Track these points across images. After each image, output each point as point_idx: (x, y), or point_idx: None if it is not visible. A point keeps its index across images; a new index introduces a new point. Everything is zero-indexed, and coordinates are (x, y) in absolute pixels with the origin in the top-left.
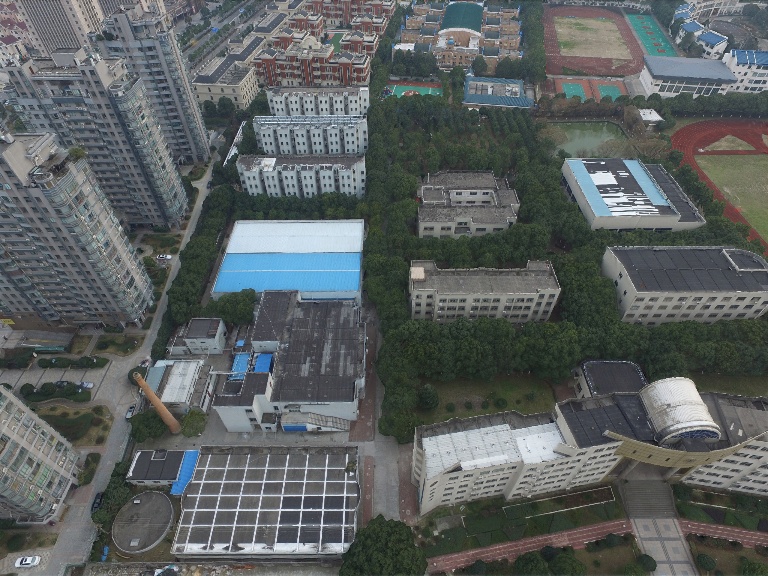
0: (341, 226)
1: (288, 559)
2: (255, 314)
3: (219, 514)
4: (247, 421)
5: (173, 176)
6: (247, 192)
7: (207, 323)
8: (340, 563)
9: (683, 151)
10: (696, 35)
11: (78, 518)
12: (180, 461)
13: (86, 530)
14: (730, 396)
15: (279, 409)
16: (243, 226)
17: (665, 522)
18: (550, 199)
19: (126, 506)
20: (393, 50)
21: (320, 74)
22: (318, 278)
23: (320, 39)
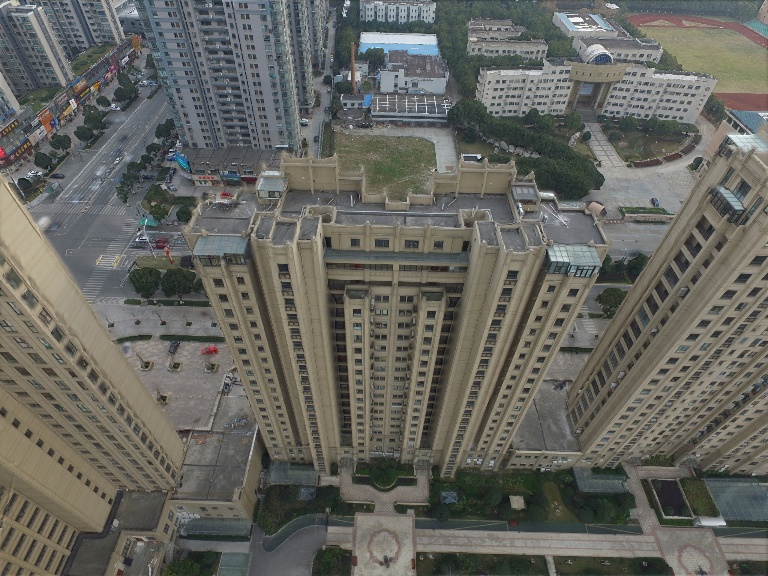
0: (423, 36)
1: (422, 121)
2: (385, 60)
3: (389, 106)
4: (393, 87)
5: (324, 6)
6: (365, 20)
7: (361, 61)
8: (444, 126)
9: None
10: None
11: (319, 114)
12: (364, 96)
13: (325, 116)
14: (622, 60)
15: (407, 84)
16: (366, 34)
17: (592, 123)
18: (545, 27)
19: (341, 111)
20: None
21: None
22: (415, 51)
23: None
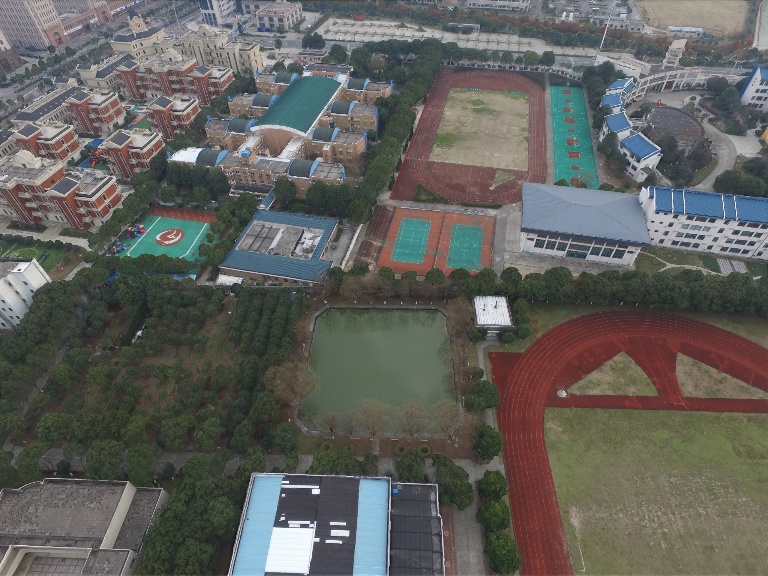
0: None
1: None
2: None
3: None
4: None
5: None
6: None
7: None
8: None
9: (530, 394)
10: (620, 137)
11: None
12: None
13: None
14: None
15: None
16: None
17: None
18: None
19: None
20: (169, 161)
21: (39, 205)
22: None
23: (113, 126)
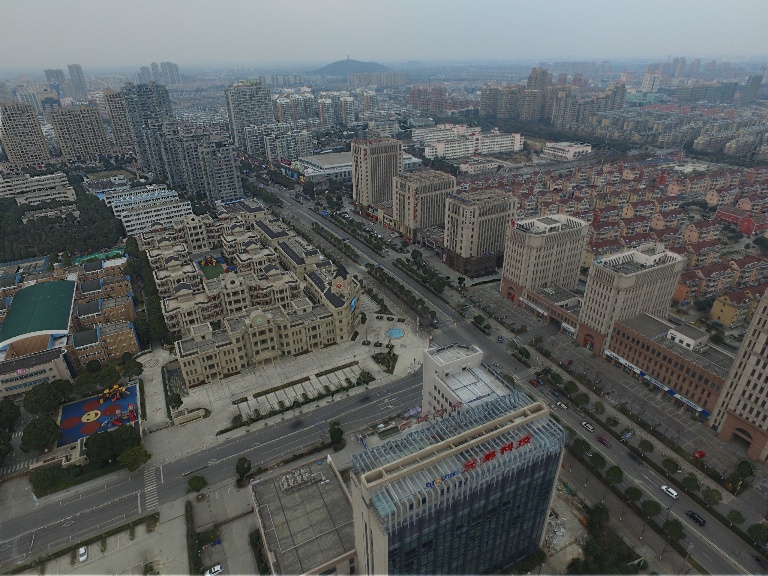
0: None
1: None
2: None
3: None
4: None
5: None
6: None
7: None
8: None
9: None
10: None
11: None
12: None
13: None
14: None
15: None
16: None
17: None
18: None
19: None
20: None
21: None
22: None
23: None
